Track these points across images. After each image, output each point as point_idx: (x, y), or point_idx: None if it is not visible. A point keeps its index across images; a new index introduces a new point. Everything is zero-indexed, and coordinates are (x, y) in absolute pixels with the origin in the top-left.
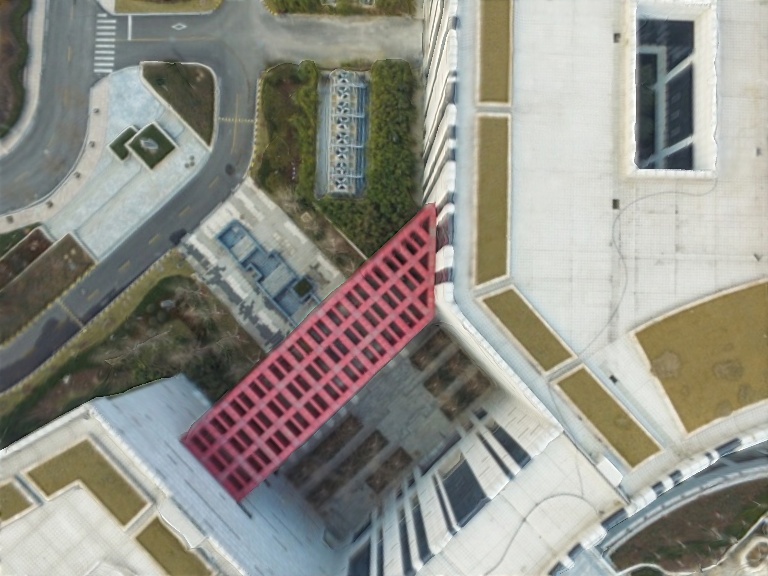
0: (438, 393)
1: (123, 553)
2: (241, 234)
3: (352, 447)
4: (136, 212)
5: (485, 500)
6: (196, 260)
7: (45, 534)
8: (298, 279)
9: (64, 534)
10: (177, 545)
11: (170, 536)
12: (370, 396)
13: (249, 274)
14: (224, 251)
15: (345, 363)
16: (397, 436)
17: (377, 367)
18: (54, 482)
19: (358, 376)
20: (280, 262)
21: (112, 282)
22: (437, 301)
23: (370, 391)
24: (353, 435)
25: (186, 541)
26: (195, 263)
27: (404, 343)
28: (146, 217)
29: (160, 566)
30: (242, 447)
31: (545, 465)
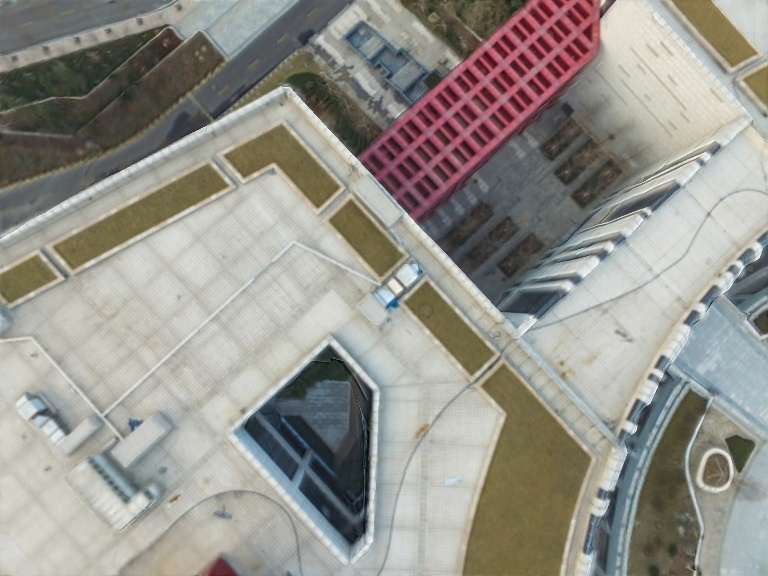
0: (569, 181)
1: (315, 237)
2: (367, 36)
3: (483, 233)
4: (265, 12)
5: (674, 187)
6: (323, 60)
7: (239, 217)
8: (428, 73)
9: (257, 218)
10: (371, 226)
11: (363, 217)
12: (500, 184)
13: (377, 72)
14: (351, 51)
15: (511, 94)
16: (527, 223)
17: (542, 99)
18: (250, 164)
19: (523, 107)
20: (408, 59)
21: (242, 79)
22: (604, 32)
23: (501, 180)
24: (484, 222)
25: (380, 222)
26: (322, 63)
27: (569, 76)
28: (275, 17)
29: (352, 248)
30: (410, 173)
31: (729, 161)
